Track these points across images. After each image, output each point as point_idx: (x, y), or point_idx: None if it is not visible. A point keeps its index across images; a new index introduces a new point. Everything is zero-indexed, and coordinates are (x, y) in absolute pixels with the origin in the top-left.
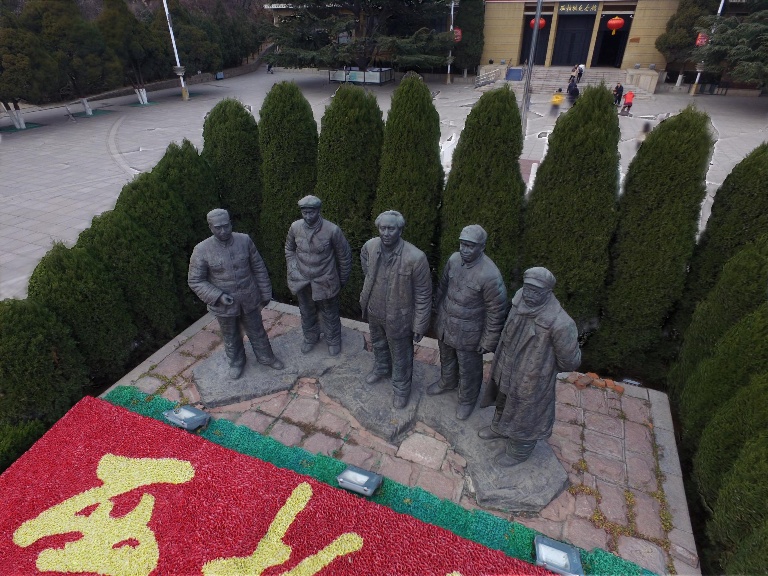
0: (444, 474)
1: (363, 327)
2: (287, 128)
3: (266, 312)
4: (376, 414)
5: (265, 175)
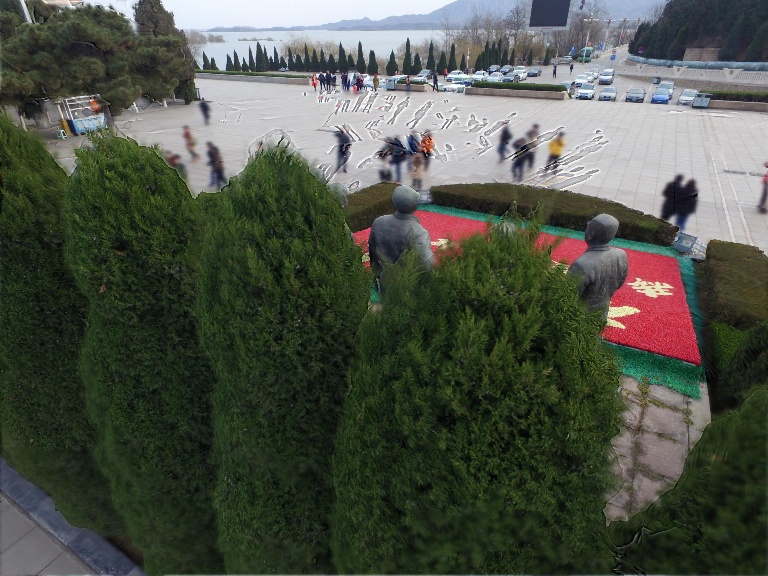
0: None
1: None
2: None
3: None
4: None
5: None
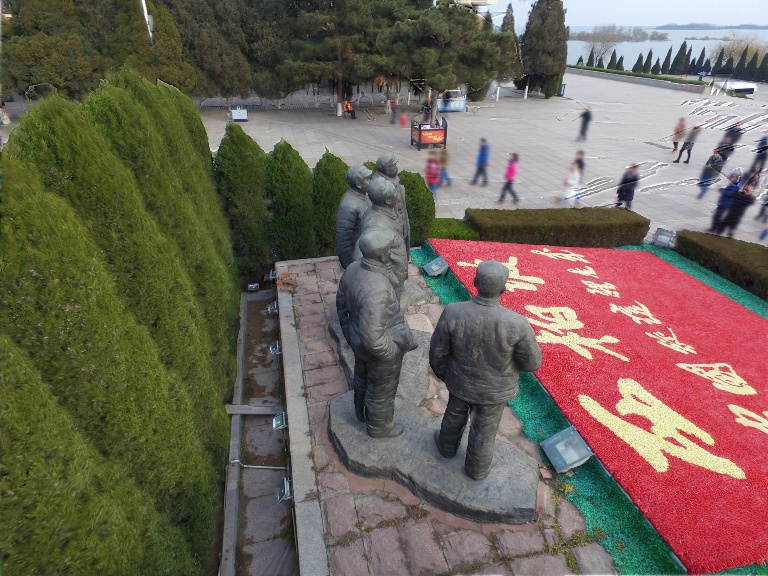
0: (427, 311)
1: (300, 429)
2: (5, 351)
3: (348, 569)
4: (421, 345)
5: (40, 574)
